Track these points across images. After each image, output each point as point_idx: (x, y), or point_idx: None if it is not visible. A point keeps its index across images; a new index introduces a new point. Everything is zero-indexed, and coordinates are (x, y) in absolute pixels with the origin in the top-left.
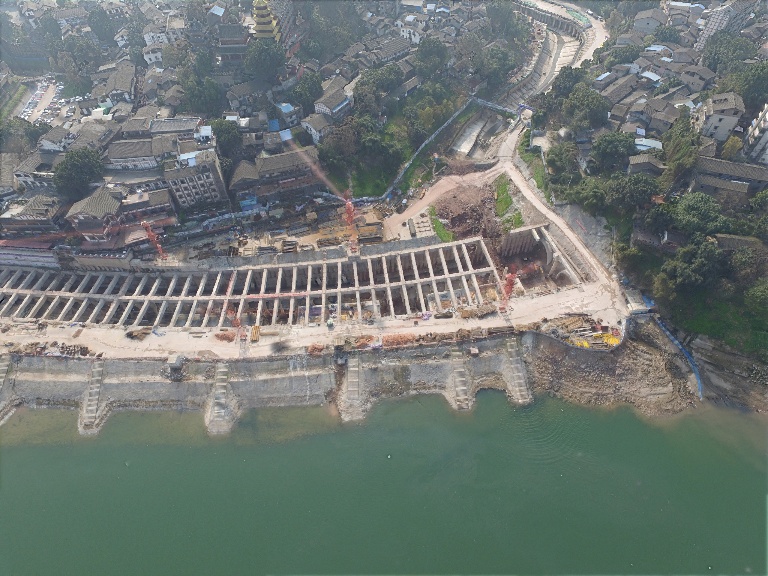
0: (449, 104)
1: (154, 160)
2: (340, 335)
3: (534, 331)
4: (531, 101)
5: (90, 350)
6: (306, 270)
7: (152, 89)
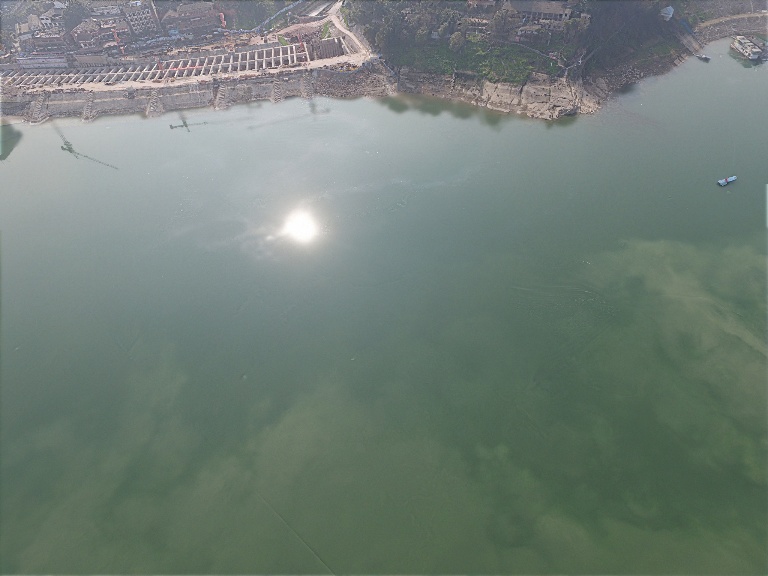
0: None
1: (118, 8)
2: (217, 77)
3: (317, 69)
4: None
5: None
6: None
7: None
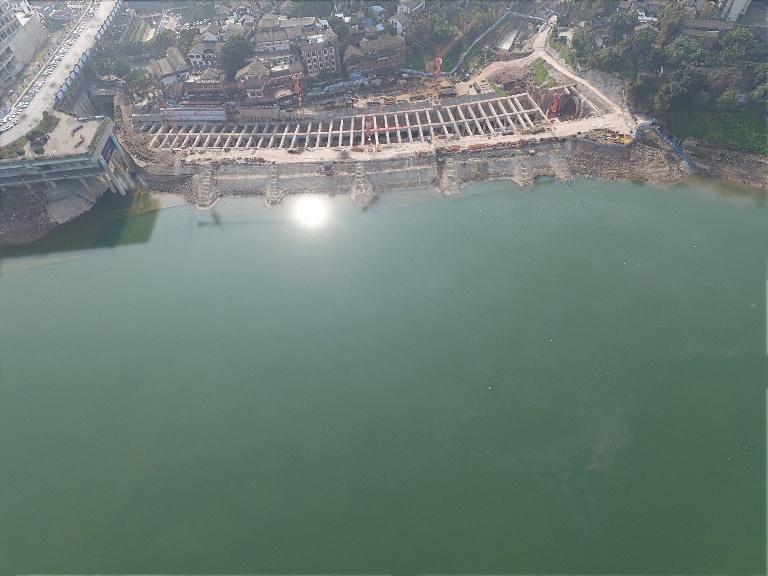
0: (493, 12)
1: (288, 44)
2: None
3: (572, 138)
4: (556, 7)
5: (266, 160)
6: (402, 118)
7: (268, 4)
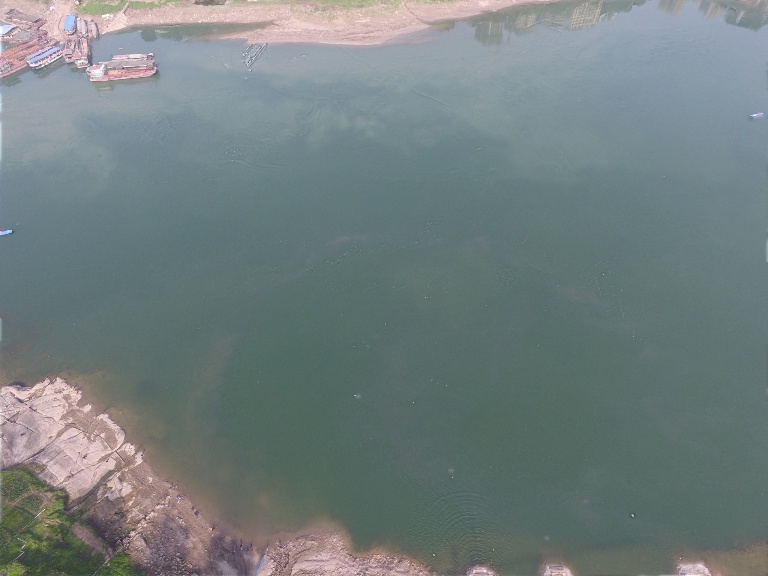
0: None
1: None
2: None
3: None
4: None
5: None
6: None
7: None
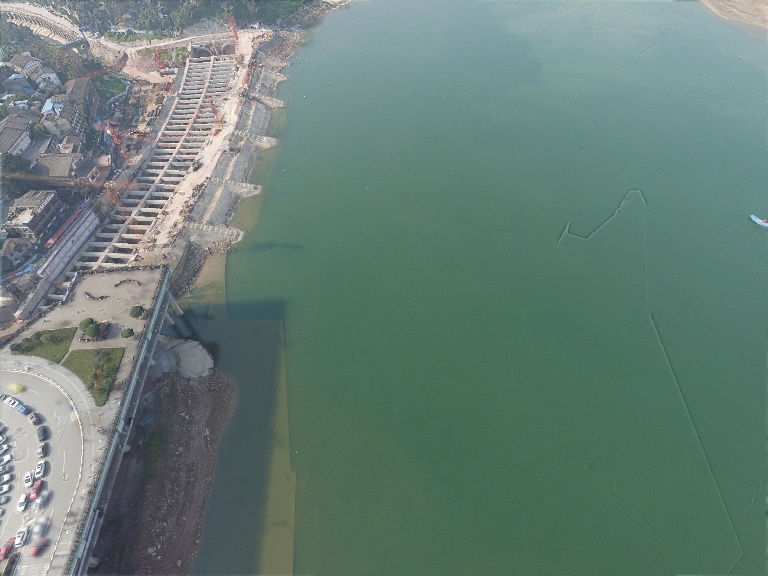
0: None
1: (26, 136)
2: (234, 96)
3: None
4: (83, 23)
5: (200, 184)
6: None
7: None
